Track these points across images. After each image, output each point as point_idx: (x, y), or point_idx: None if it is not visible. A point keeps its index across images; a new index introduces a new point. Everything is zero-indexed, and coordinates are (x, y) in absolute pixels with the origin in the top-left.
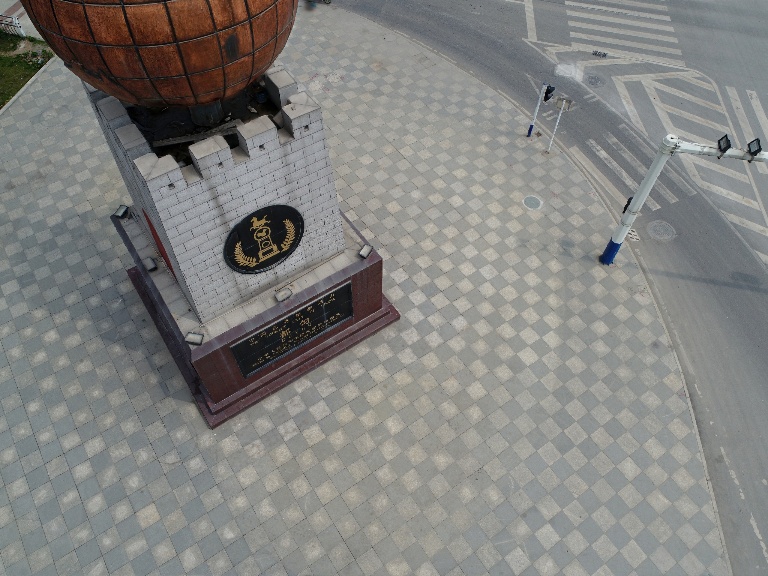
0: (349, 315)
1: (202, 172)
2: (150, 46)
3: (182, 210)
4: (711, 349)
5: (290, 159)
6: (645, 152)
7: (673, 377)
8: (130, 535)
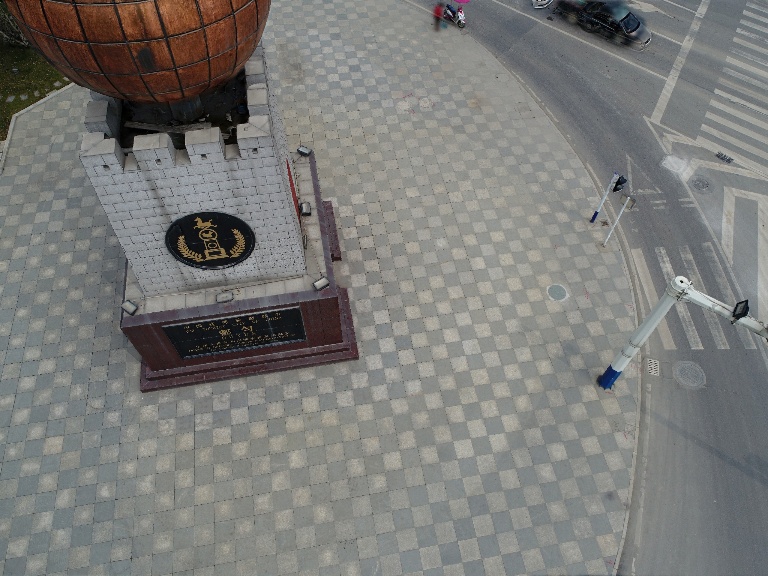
0: (302, 337)
1: (139, 163)
2: (65, 40)
3: (119, 191)
4: (675, 528)
5: (237, 175)
6: (718, 282)
7: (611, 539)
8: (32, 455)
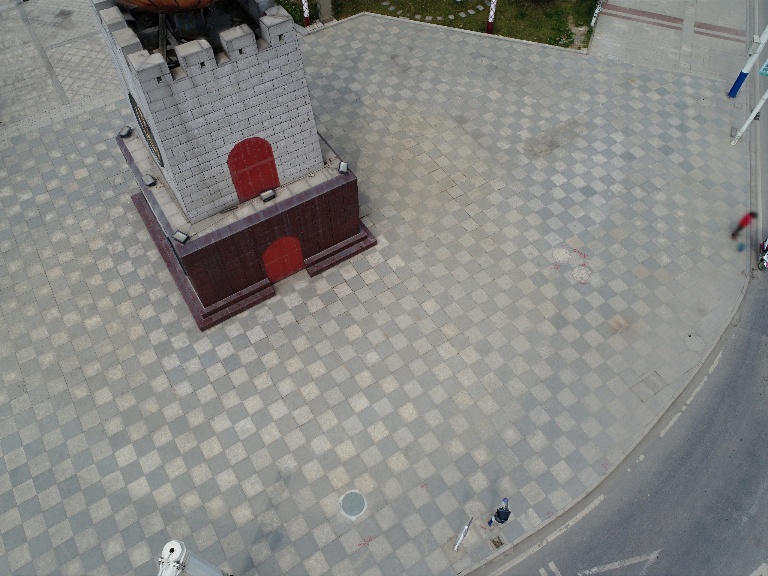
0: None
1: None
2: None
3: None
4: None
5: None
6: None
7: None
8: (72, 166)
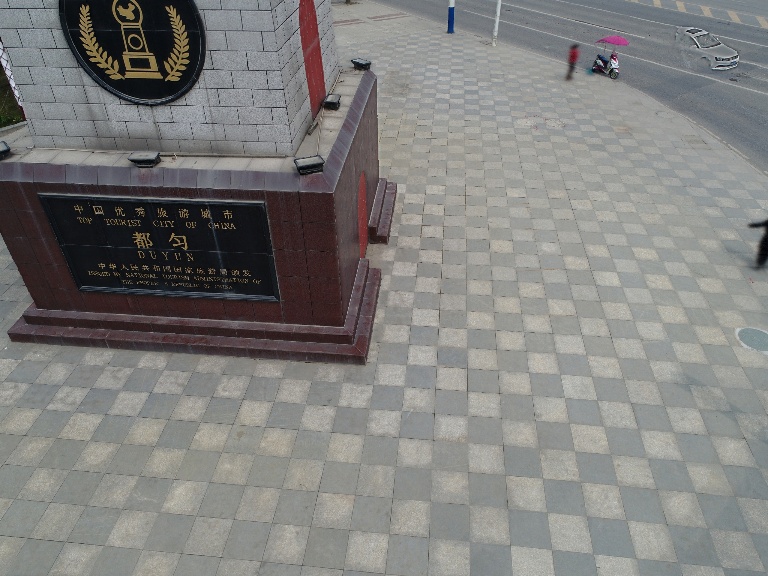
0: (272, 293)
1: None
2: None
3: None
4: None
5: None
6: None
7: None
8: None
